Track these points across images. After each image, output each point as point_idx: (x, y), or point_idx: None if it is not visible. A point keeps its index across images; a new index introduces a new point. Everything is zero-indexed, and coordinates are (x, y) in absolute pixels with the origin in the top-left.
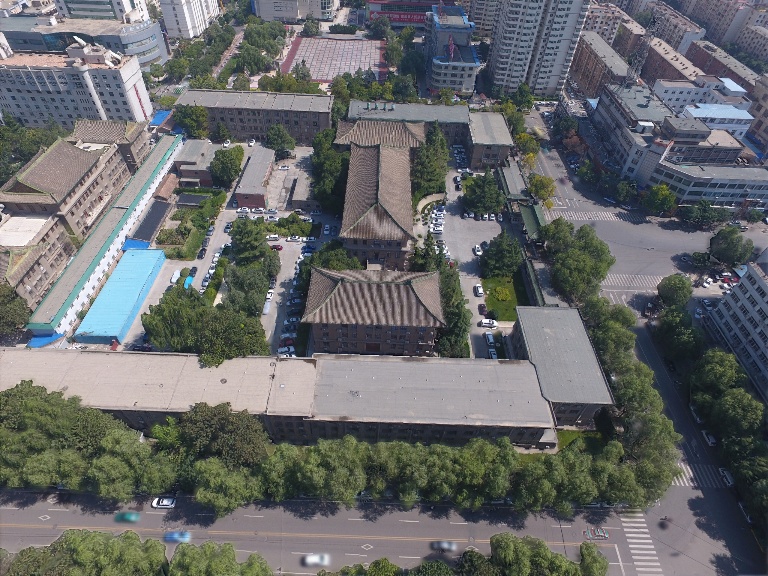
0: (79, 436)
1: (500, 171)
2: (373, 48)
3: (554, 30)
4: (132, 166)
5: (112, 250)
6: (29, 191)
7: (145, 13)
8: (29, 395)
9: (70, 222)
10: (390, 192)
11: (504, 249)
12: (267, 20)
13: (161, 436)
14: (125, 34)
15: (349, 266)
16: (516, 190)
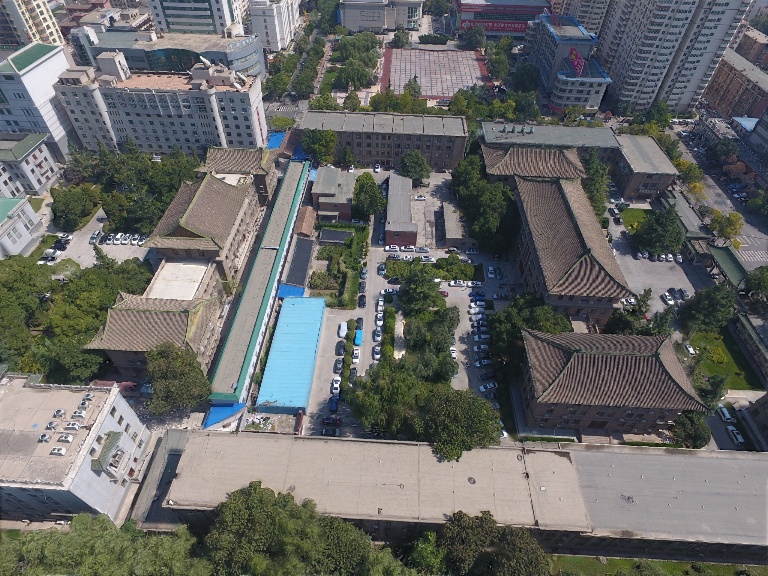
0: (331, 557)
1: (666, 203)
2: (469, 59)
3: (699, 43)
4: (263, 197)
5: (270, 298)
6: (189, 235)
7: (240, 26)
8: (269, 505)
9: (225, 267)
10: (589, 238)
11: (718, 303)
12: (352, 30)
13: (432, 561)
14: (231, 50)
15: None
16: (693, 226)
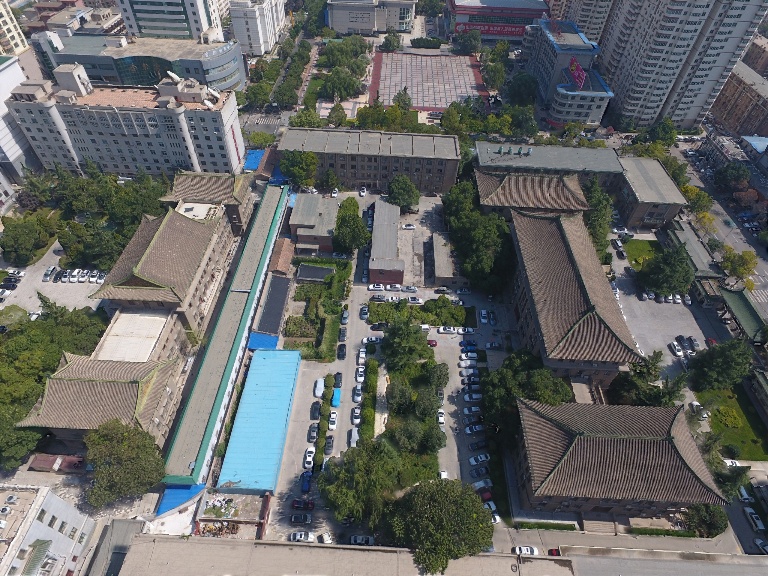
0: None
1: (673, 236)
2: (464, 66)
3: (708, 56)
4: (236, 227)
5: (238, 351)
6: (145, 285)
7: (219, 29)
8: None
9: (188, 317)
10: (593, 288)
11: (734, 361)
12: (340, 32)
13: None
14: (207, 58)
15: (558, 394)
16: (703, 264)
